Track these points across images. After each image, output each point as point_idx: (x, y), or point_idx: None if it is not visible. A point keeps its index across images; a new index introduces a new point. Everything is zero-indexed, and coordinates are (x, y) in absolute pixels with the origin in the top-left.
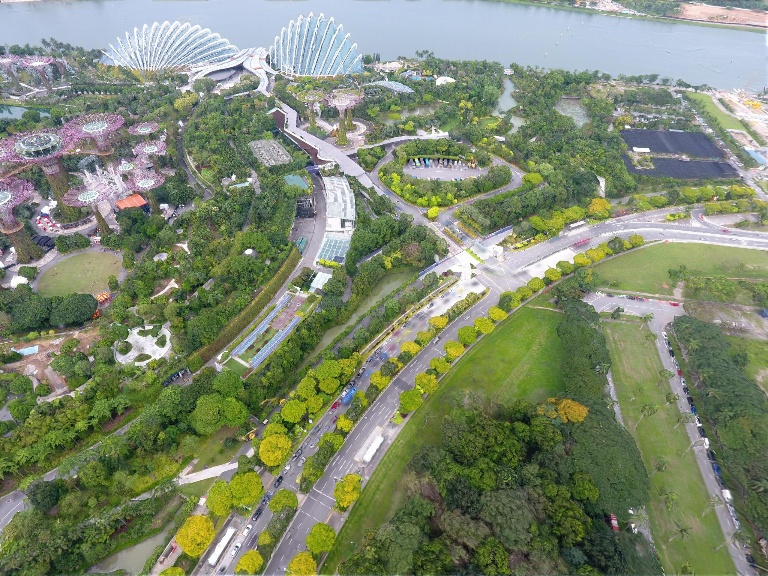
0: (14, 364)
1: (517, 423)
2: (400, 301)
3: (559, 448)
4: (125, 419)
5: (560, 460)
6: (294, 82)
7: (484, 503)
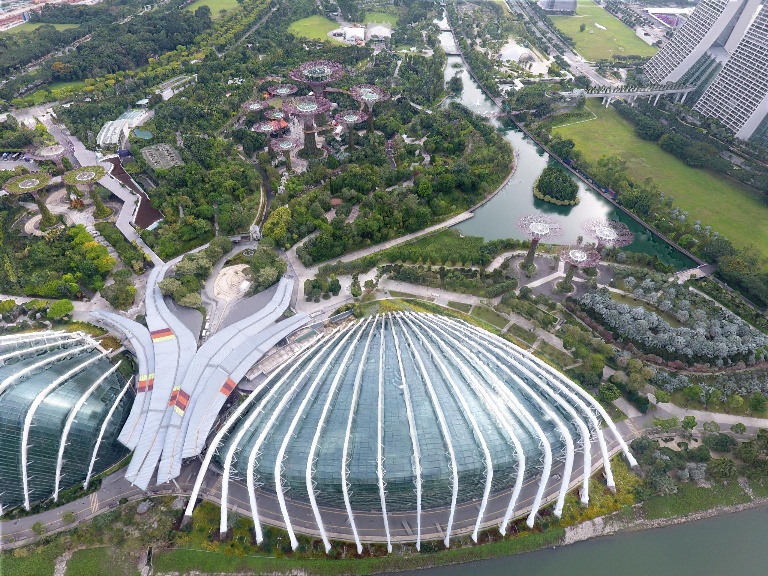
0: None
1: None
2: (104, 90)
3: None
4: None
5: None
6: (93, 324)
7: None
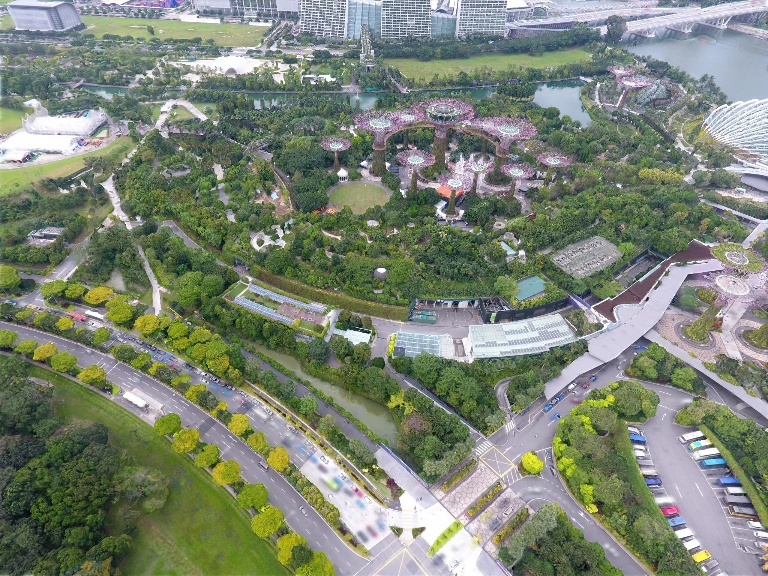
0: (265, 195)
1: (82, 527)
2: (311, 410)
3: (26, 575)
4: (214, 252)
5: (14, 575)
6: None
7: (4, 469)
